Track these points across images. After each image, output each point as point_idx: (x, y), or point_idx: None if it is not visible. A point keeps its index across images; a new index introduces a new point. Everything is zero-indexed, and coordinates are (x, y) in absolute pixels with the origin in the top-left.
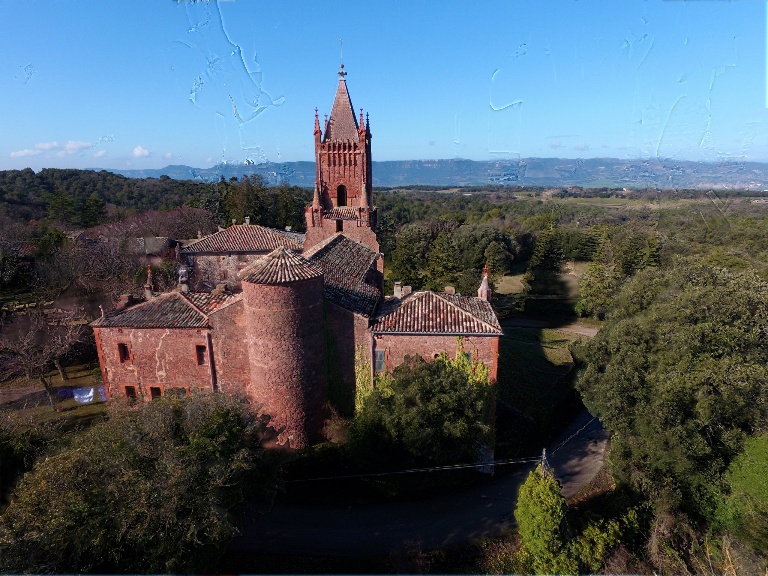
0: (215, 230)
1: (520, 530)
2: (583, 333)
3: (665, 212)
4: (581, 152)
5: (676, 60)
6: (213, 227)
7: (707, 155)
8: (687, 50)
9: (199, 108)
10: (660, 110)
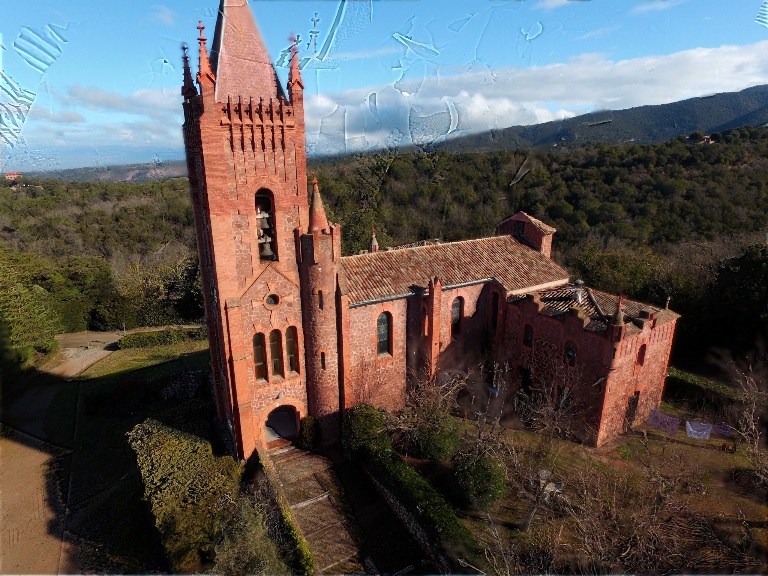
0: None
1: None
2: (87, 363)
3: None
4: None
5: None
6: None
7: None
8: None
9: (503, 4)
10: None
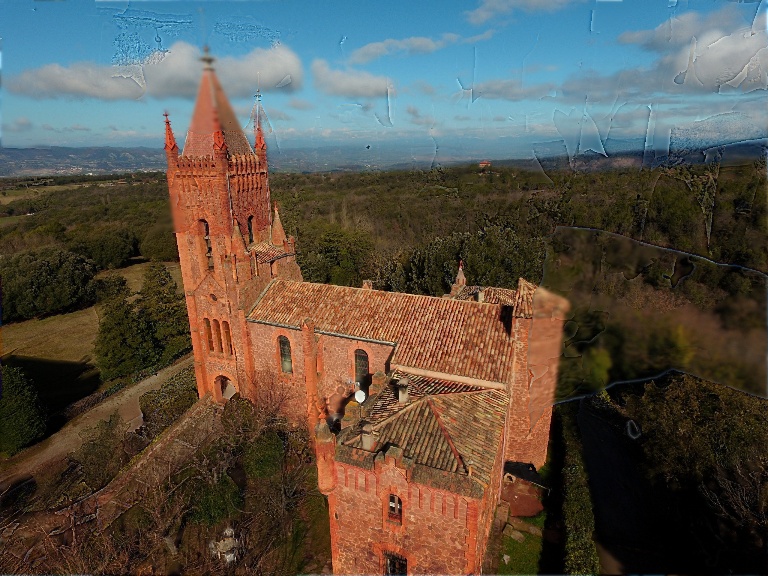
0: None
1: None
2: None
3: None
4: None
5: None
6: None
7: None
8: None
9: None
10: None
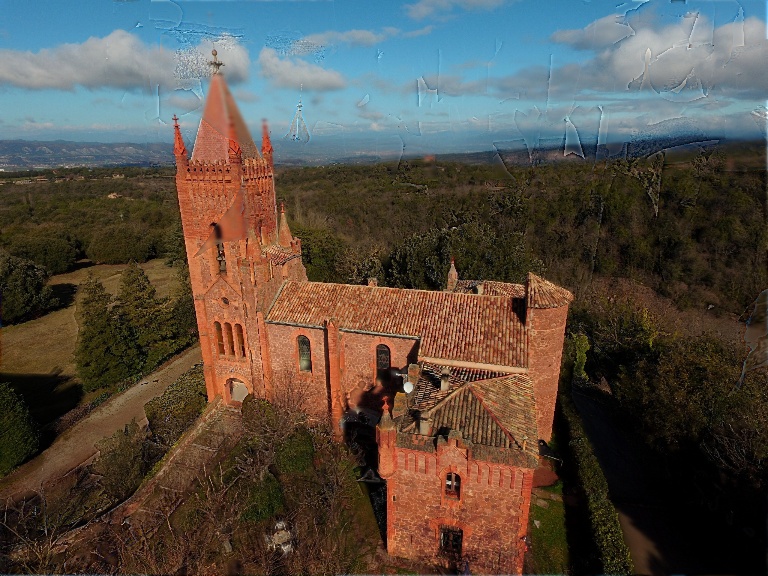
0: None
1: (578, 368)
2: None
3: (175, 203)
4: None
5: None
6: None
7: None
8: None
9: None
10: (136, 105)
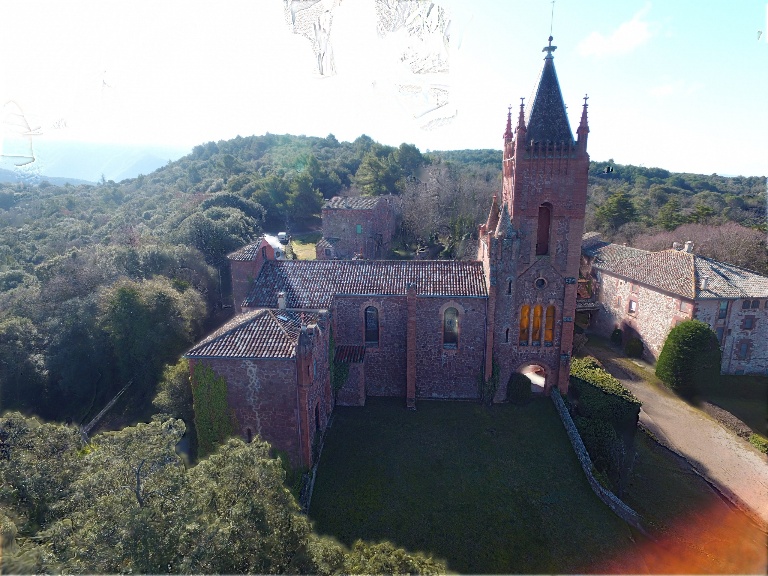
0: (763, 260)
1: None
2: None
3: None
4: None
5: None
6: (762, 255)
7: None
8: None
9: None
10: None
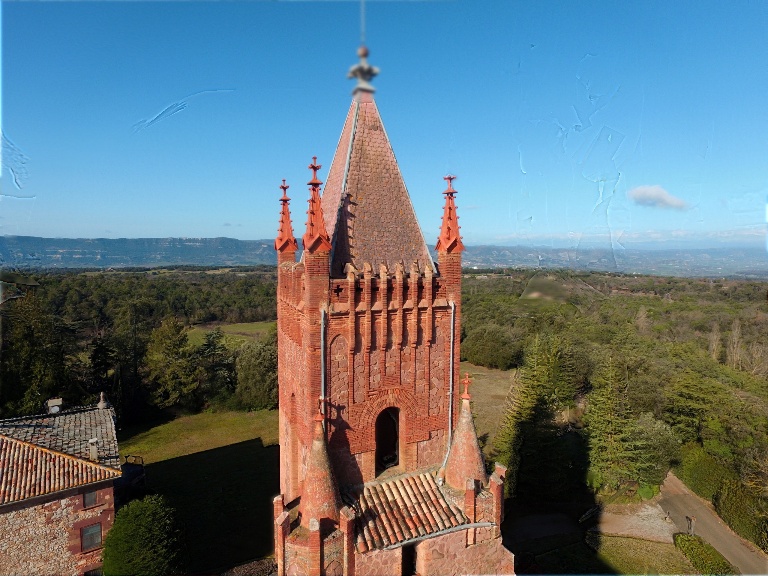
0: None
1: None
2: (632, 532)
3: None
4: (559, 260)
5: (590, 158)
6: None
7: (574, 254)
8: (604, 148)
9: None
10: None
